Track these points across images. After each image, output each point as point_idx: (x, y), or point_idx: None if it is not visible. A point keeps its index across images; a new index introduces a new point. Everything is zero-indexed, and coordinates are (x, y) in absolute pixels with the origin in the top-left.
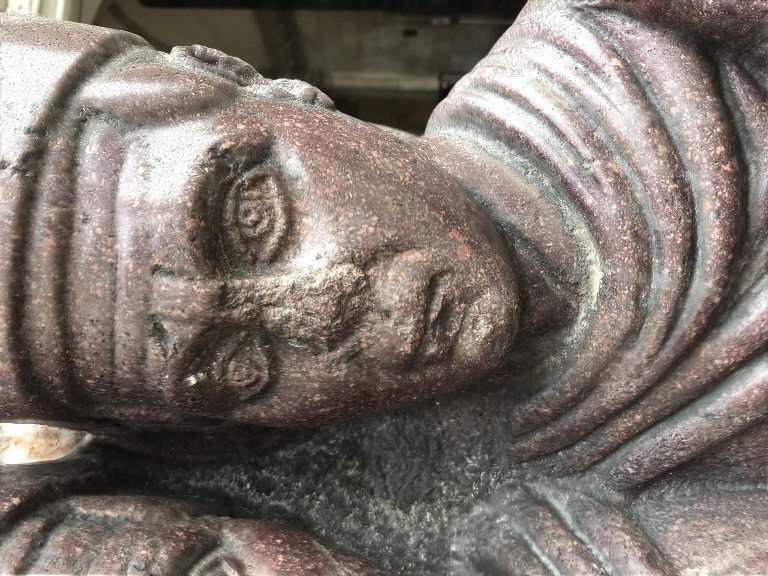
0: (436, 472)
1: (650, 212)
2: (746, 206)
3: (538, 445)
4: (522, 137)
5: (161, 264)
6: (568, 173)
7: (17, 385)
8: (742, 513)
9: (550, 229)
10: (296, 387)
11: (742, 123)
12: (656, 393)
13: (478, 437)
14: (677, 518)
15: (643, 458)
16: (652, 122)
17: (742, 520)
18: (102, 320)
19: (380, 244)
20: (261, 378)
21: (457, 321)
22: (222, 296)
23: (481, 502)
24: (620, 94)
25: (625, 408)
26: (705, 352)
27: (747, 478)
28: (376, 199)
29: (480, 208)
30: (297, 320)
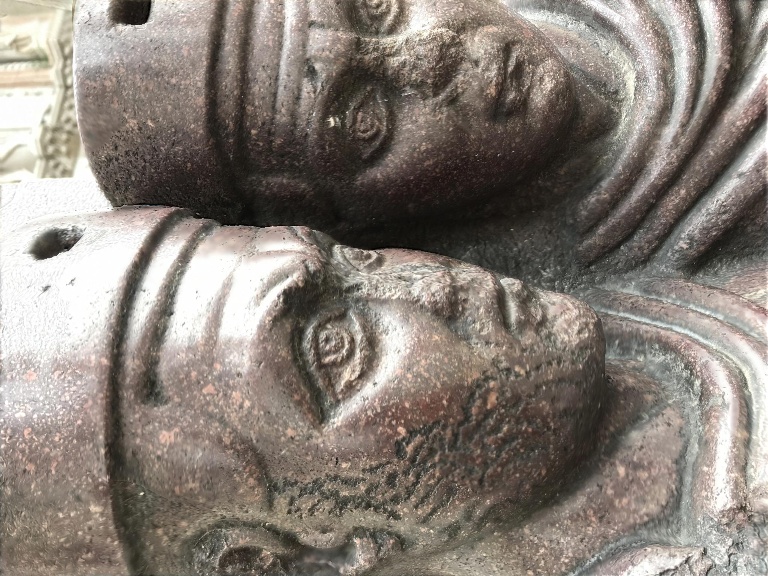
0: None
1: (665, 14)
2: (737, 2)
3: (602, 238)
4: None
5: (316, 19)
6: (599, 5)
7: (205, 122)
8: None
9: (590, 55)
10: (407, 139)
11: None
12: (694, 165)
13: (549, 252)
14: (731, 277)
15: (693, 231)
16: None
17: None
18: (271, 66)
19: (467, 17)
20: (380, 132)
21: (528, 79)
22: (357, 44)
23: None
24: None
25: (671, 184)
26: (727, 118)
27: None
28: None
29: None
30: (411, 64)
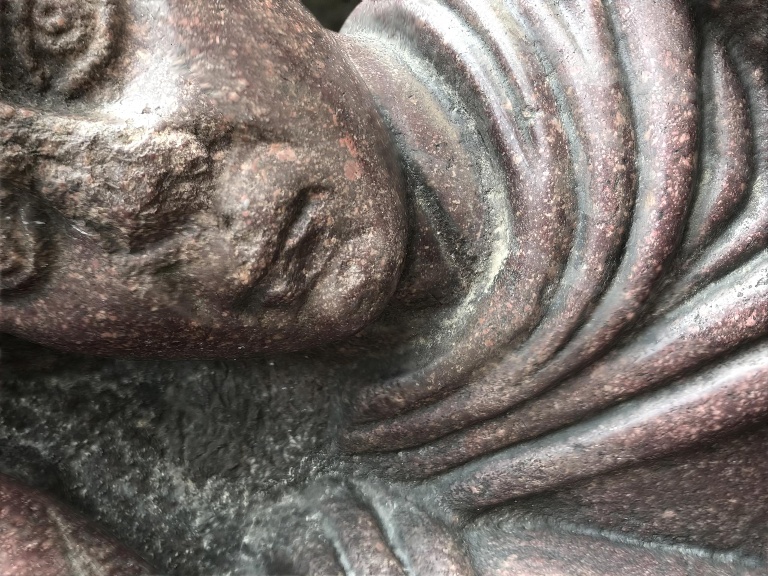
0: (249, 446)
1: (585, 191)
2: (689, 215)
3: (378, 439)
4: (460, 60)
5: None
6: (503, 118)
7: None
8: (580, 560)
9: (462, 183)
10: (73, 293)
11: (713, 116)
12: (528, 408)
13: (310, 415)
14: (510, 553)
15: (492, 479)
16: (618, 82)
17: (579, 569)
18: None
19: (242, 120)
20: (22, 268)
21: (321, 259)
22: None
23: (294, 492)
24: (590, 37)
25: (489, 418)
26: (596, 373)
27: (593, 522)
28: (253, 58)
29: (387, 128)
30: (89, 192)
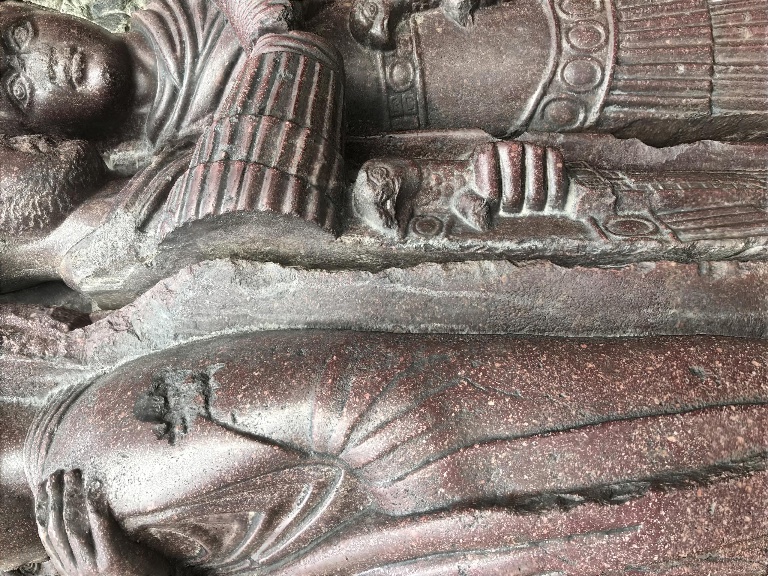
0: None
1: None
2: None
3: None
4: None
5: None
6: None
7: None
8: None
9: None
10: None
11: None
12: None
13: None
14: None
15: None
16: None
17: None
18: None
19: None
20: None
21: None
22: None
23: None
24: None
25: None
26: None
27: None
28: None
29: None
30: None
